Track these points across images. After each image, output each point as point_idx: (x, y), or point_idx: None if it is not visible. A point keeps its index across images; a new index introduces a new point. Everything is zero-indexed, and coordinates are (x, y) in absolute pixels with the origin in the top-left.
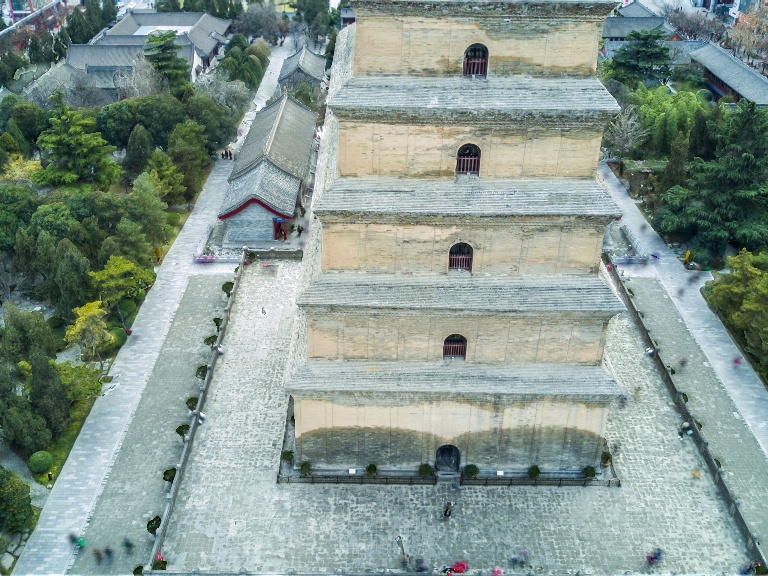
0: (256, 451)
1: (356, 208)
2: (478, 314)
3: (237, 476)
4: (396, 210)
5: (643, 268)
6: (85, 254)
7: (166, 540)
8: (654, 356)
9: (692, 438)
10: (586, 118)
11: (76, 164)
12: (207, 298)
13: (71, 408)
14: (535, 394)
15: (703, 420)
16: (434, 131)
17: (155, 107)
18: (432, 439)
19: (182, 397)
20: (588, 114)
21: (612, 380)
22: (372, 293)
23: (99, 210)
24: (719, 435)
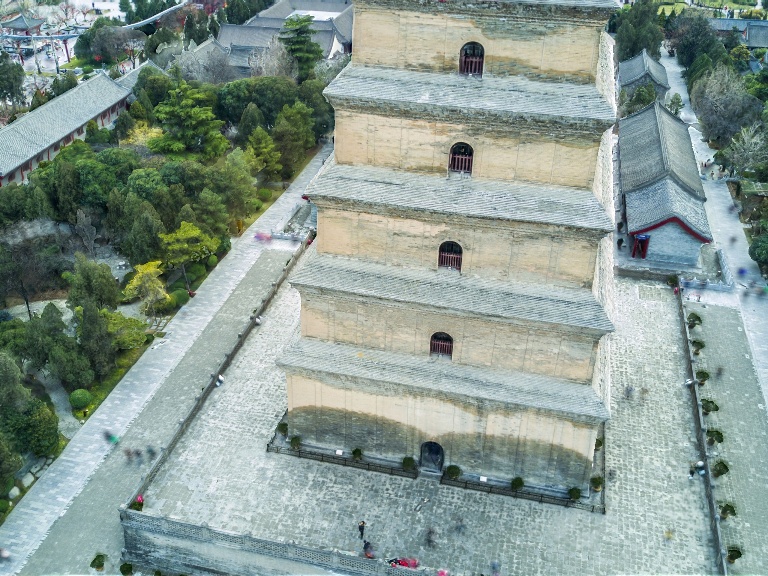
0: (258, 419)
1: (346, 195)
2: (463, 315)
3: (233, 439)
4: (384, 201)
5: (725, 296)
6: (167, 218)
7: (152, 485)
8: (691, 388)
9: (703, 479)
10: (580, 126)
11: (185, 135)
12: (272, 272)
13: (122, 356)
14: (517, 404)
15: (735, 464)
16: (427, 127)
17: (270, 87)
18: (417, 433)
19: (220, 360)
20: (582, 122)
21: (600, 402)
22: (360, 281)
23: (188, 179)
24: (748, 482)
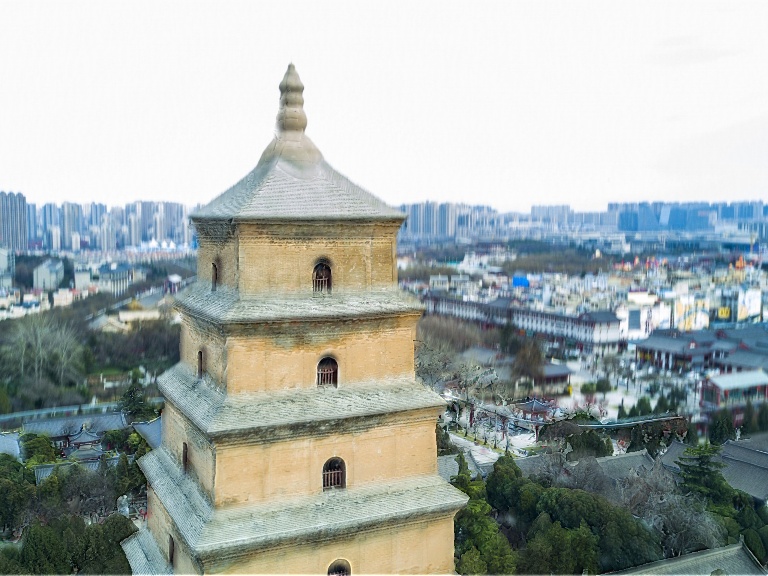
0: None
1: None
2: None
3: None
4: None
5: None
6: None
7: None
8: None
9: None
10: None
11: None
12: None
13: None
14: None
15: None
16: None
17: (570, 502)
18: None
19: None
20: None
21: None
22: None
23: None
24: None
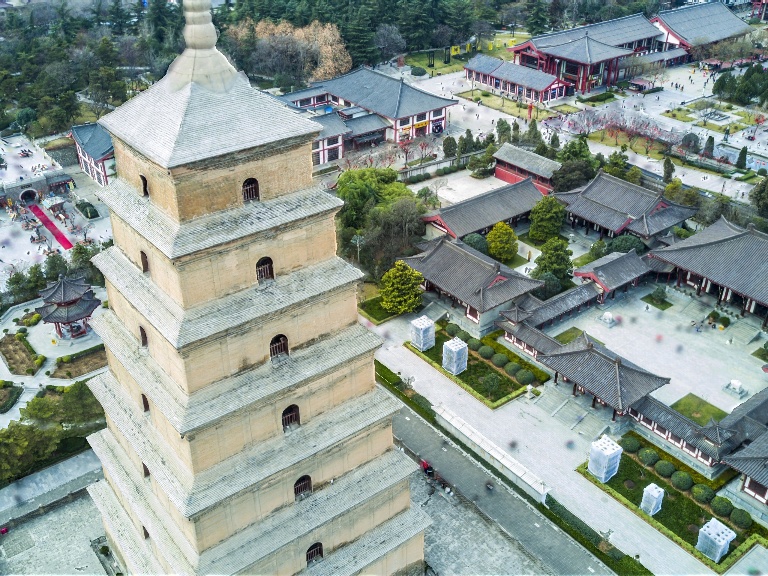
0: None
1: None
2: None
3: None
4: None
5: None
6: None
7: None
8: None
9: None
10: None
11: None
12: None
13: None
14: None
15: None
16: None
17: None
18: None
19: None
20: None
21: None
22: None
23: None
24: None
